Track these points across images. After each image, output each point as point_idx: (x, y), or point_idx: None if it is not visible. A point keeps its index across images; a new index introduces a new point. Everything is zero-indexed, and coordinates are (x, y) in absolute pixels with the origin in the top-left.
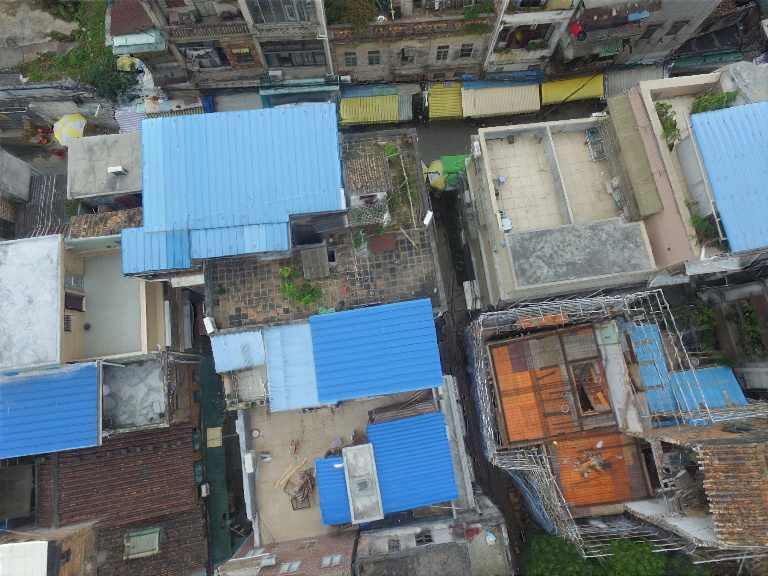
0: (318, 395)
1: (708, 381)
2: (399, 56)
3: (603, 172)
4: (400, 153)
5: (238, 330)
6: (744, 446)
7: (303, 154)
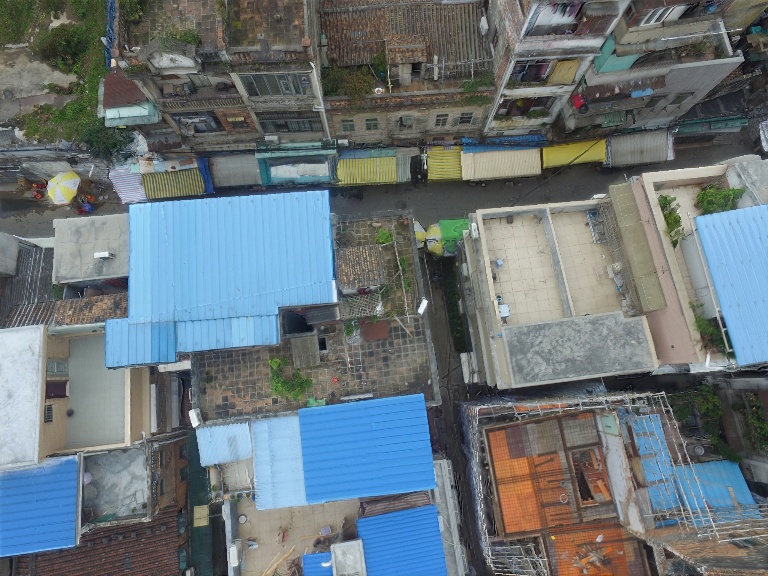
0: (305, 494)
1: (713, 476)
2: (397, 123)
3: (605, 255)
4: (394, 242)
5: (224, 422)
6: (751, 572)
7: (294, 243)
